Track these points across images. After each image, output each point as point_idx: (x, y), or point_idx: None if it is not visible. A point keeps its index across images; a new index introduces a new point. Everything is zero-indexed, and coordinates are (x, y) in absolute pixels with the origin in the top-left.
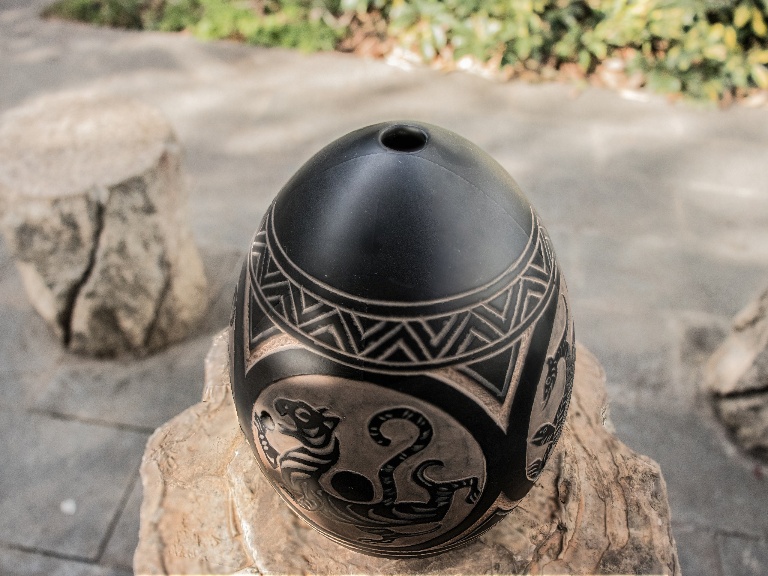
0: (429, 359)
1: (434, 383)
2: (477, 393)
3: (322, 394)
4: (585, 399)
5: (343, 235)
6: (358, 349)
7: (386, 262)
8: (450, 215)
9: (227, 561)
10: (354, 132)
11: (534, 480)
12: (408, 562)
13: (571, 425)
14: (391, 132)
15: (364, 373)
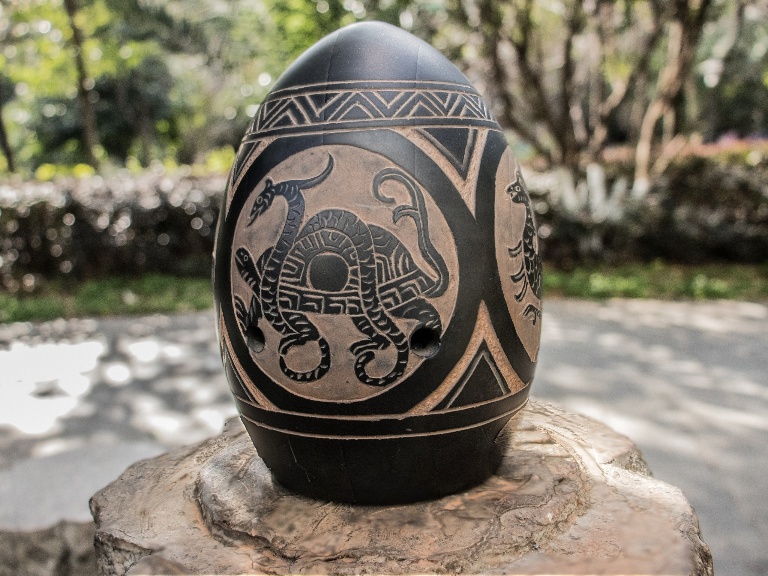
0: None
1: None
2: None
3: None
4: None
5: None
6: None
7: None
8: None
9: None
10: None
11: (253, 355)
12: None
13: None
14: None
15: None
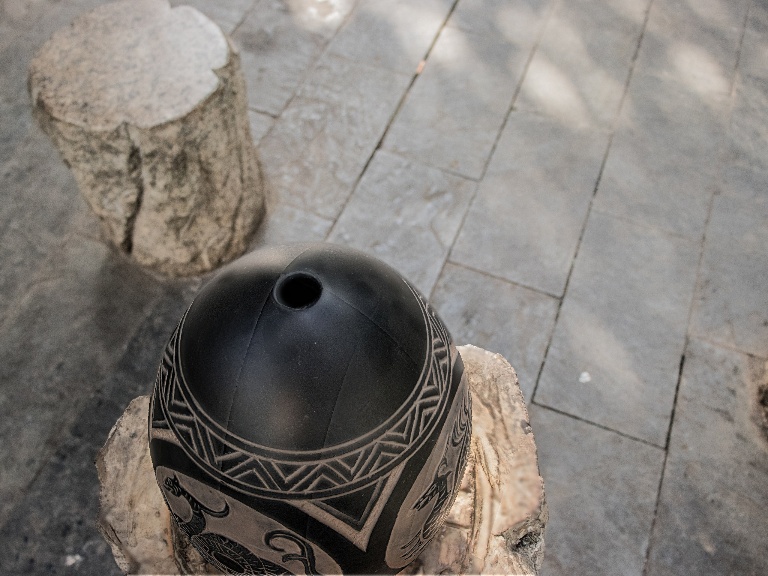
0: None
1: None
2: None
3: None
4: None
5: None
6: None
7: None
8: (220, 328)
9: None
10: (350, 270)
11: None
12: None
13: None
14: None
15: None
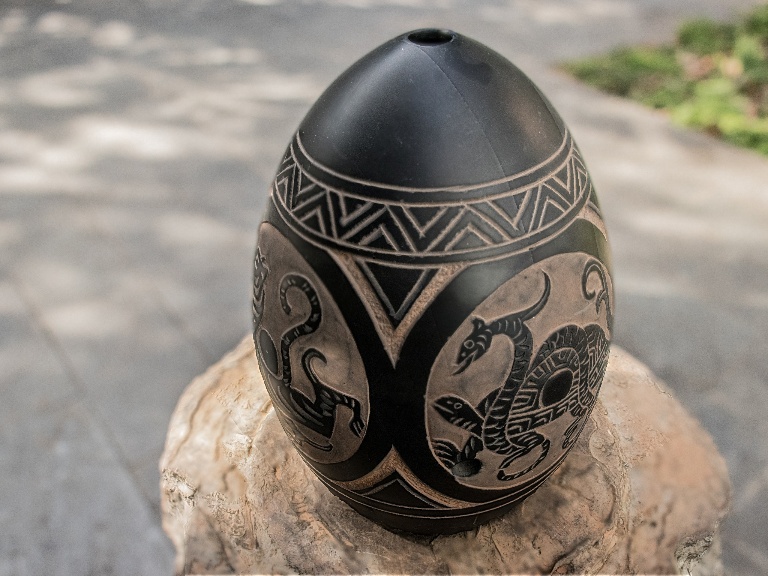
0: (334, 237)
1: (332, 264)
2: (370, 299)
3: (266, 243)
4: (677, 516)
5: (328, 100)
6: (292, 205)
7: (339, 129)
8: (412, 107)
9: (241, 423)
10: None
11: (459, 479)
12: (356, 516)
13: (635, 528)
14: (433, 34)
15: (289, 230)
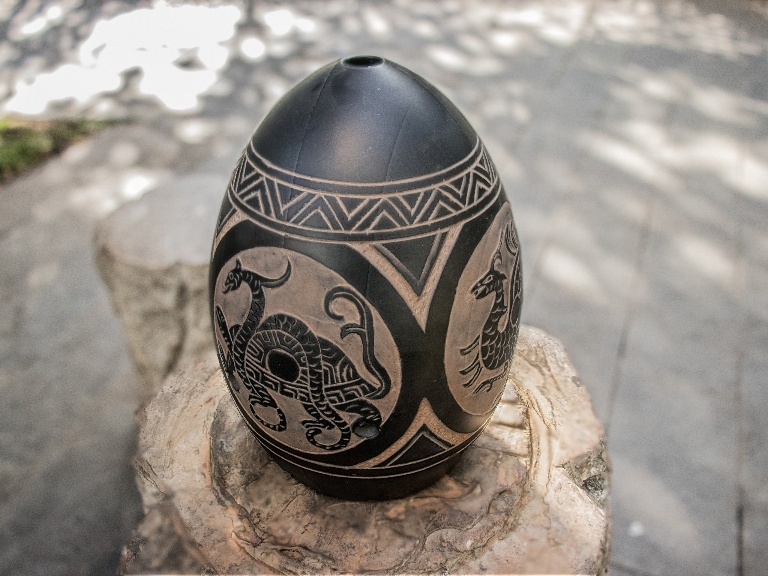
0: None
1: None
2: None
3: None
4: None
5: None
6: None
7: None
8: None
9: None
10: None
11: None
12: None
13: None
14: None
15: None
